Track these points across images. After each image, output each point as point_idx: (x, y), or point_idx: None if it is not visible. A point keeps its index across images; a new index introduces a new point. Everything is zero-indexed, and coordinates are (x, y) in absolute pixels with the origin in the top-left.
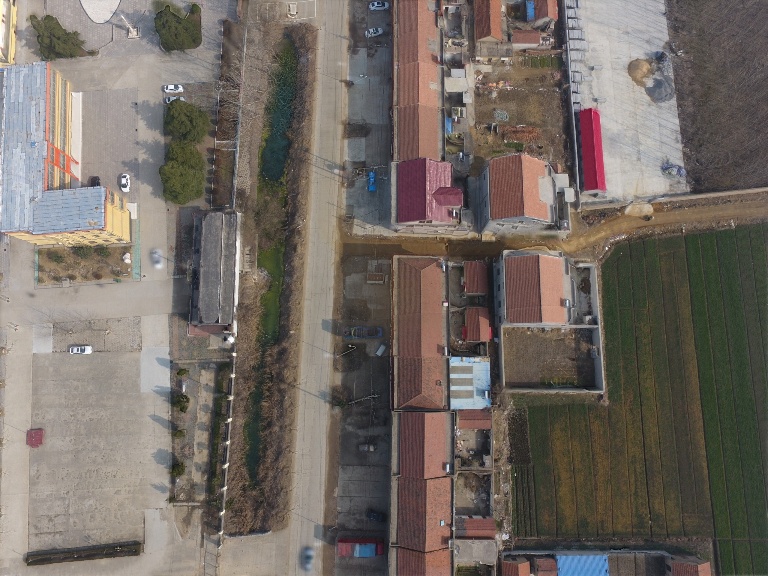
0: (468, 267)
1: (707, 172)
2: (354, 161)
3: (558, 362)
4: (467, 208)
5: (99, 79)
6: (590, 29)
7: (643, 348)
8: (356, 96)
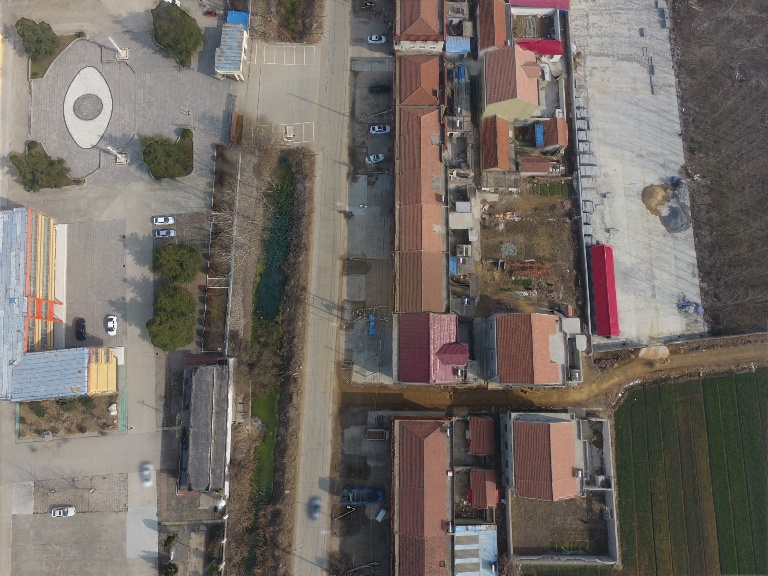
0: (474, 424)
1: (725, 309)
2: (353, 301)
3: (569, 524)
4: (473, 359)
5: (85, 209)
6: (602, 152)
7: (659, 505)
8: (356, 228)
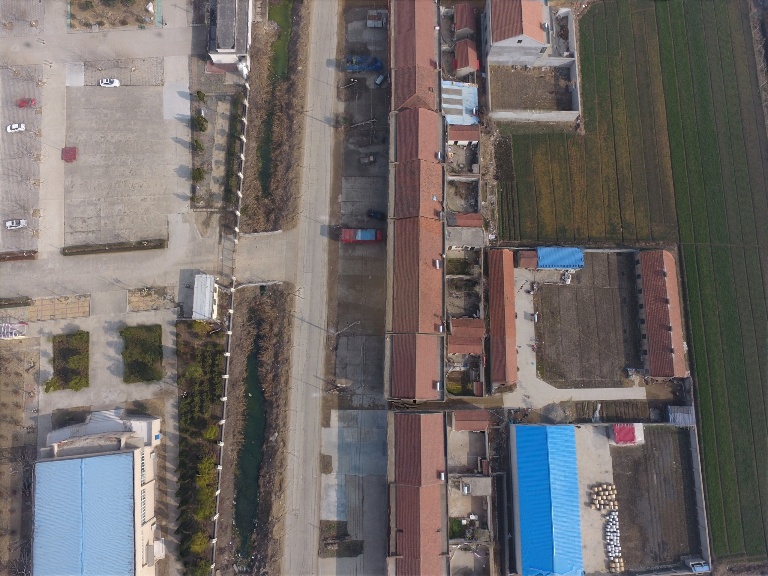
0: (458, 9)
1: None
2: None
3: (539, 95)
4: None
5: None
6: None
7: (616, 88)
8: None
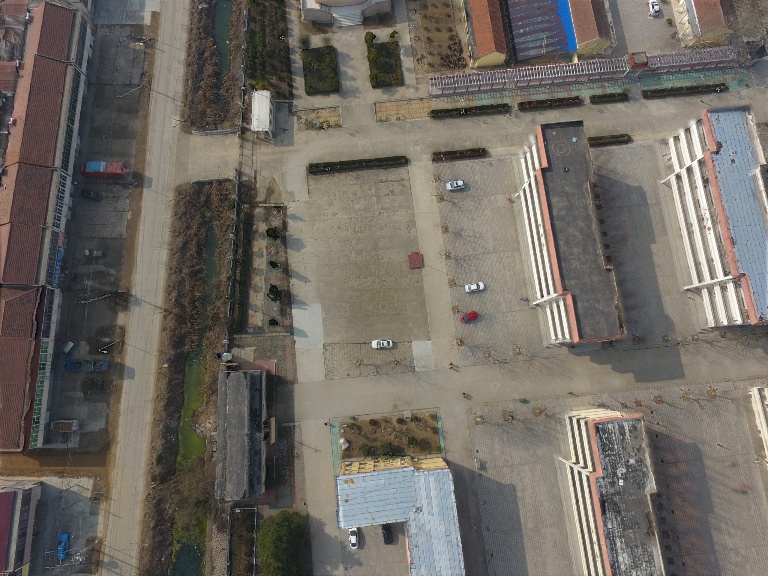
0: None
1: None
2: (84, 574)
3: None
4: None
5: None
6: None
7: None
8: None
